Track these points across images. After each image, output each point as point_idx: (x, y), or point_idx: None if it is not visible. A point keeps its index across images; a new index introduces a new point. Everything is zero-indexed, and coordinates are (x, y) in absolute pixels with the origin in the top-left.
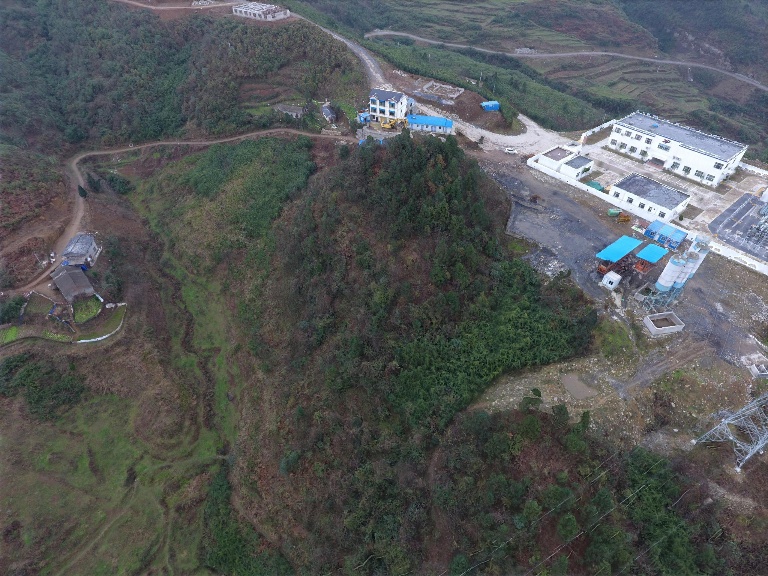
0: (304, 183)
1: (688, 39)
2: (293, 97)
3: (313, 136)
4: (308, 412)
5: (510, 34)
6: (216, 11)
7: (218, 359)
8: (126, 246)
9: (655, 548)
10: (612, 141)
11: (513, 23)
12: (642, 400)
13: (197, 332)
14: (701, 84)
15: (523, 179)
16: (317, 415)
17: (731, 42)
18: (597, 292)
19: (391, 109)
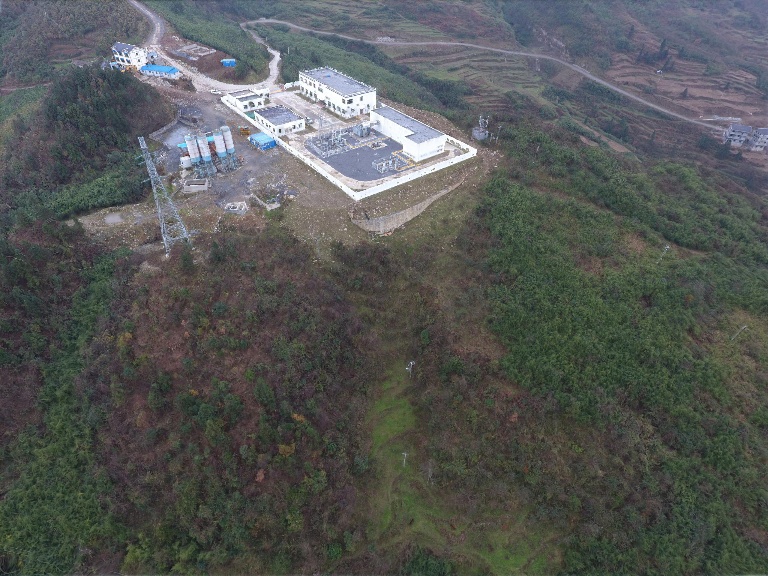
0: None
1: (543, 34)
2: (91, 55)
3: None
4: None
5: (373, 24)
6: None
7: None
8: None
9: (80, 288)
10: (302, 88)
11: (381, 15)
12: (148, 225)
13: None
14: (546, 73)
15: (204, 109)
16: None
17: (571, 37)
18: (173, 169)
19: (127, 58)
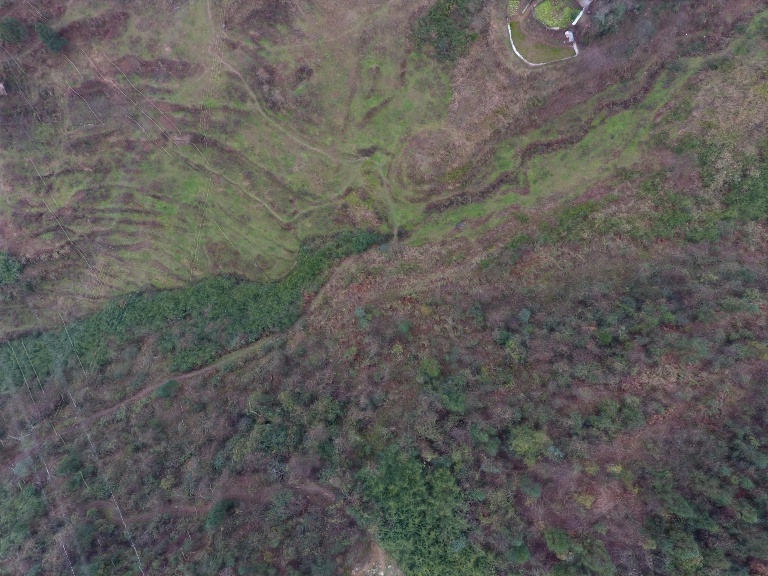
0: None
1: None
2: None
3: None
4: (407, 335)
5: None
6: None
7: (512, 196)
8: (699, 0)
9: None
10: None
11: None
12: None
13: (552, 157)
14: None
15: None
16: (397, 349)
17: None
18: None
19: None
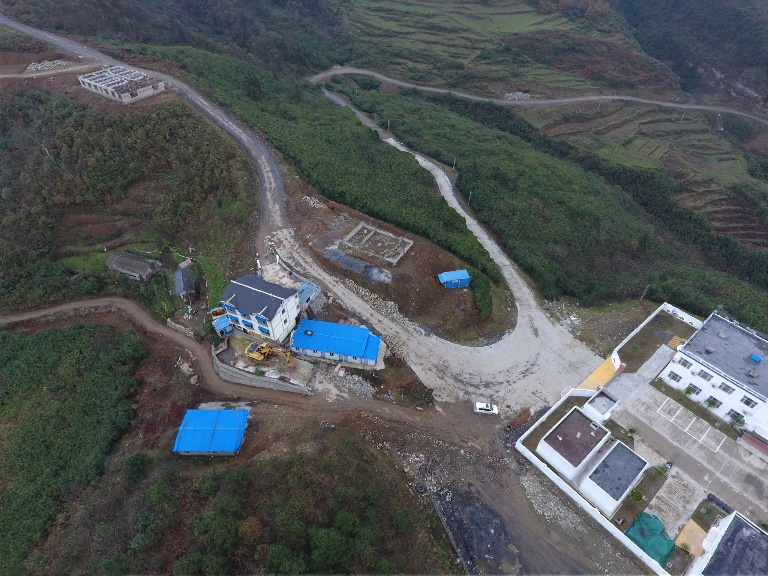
0: (97, 467)
1: (716, 77)
2: (143, 238)
3: (152, 331)
4: None
5: (499, 75)
6: (56, 81)
7: None
8: None
9: None
10: (671, 374)
11: (503, 59)
12: None
13: None
14: (734, 135)
15: (507, 513)
16: None
17: None
18: None
19: (262, 326)
